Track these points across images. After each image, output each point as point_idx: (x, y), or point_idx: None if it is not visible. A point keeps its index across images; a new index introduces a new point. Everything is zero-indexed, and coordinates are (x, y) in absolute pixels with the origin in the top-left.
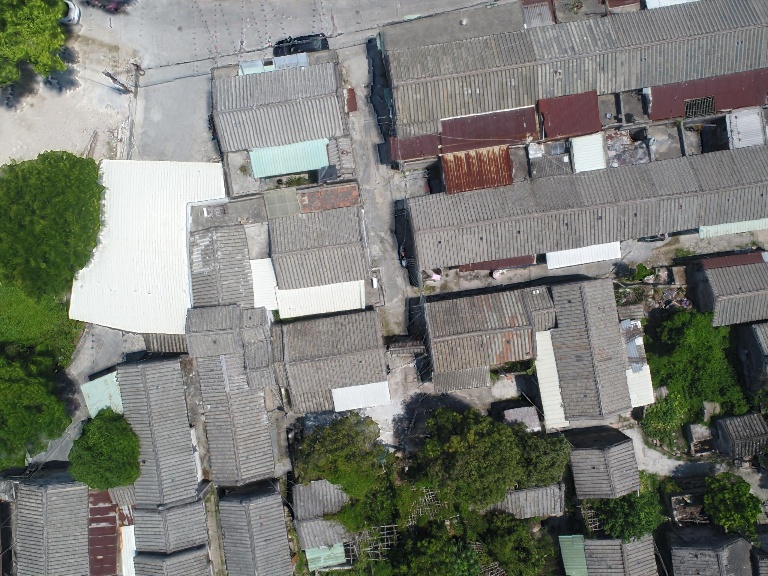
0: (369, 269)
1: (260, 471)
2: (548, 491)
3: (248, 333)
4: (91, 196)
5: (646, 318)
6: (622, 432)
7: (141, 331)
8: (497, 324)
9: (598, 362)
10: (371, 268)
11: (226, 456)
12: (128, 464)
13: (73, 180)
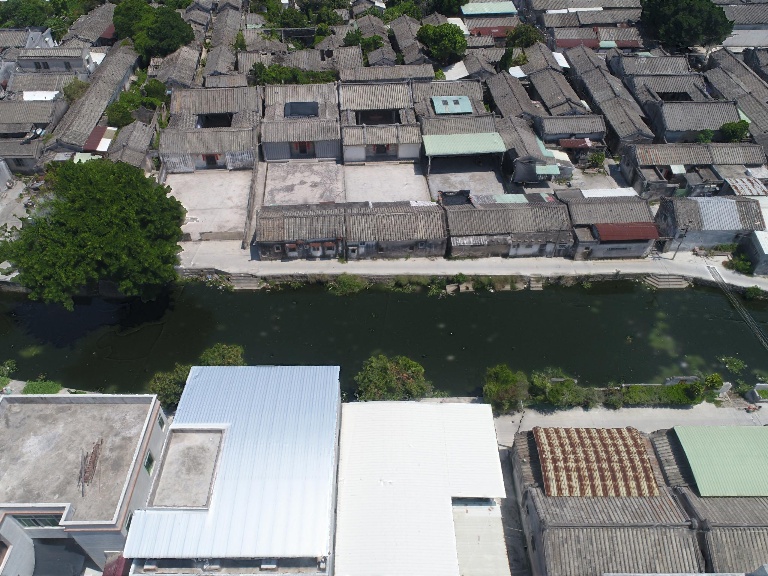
0: None
1: (236, 5)
2: (343, 11)
3: None
4: None
5: (385, 2)
6: None
7: None
8: None
9: None
10: None
11: (224, 2)
12: None
13: None
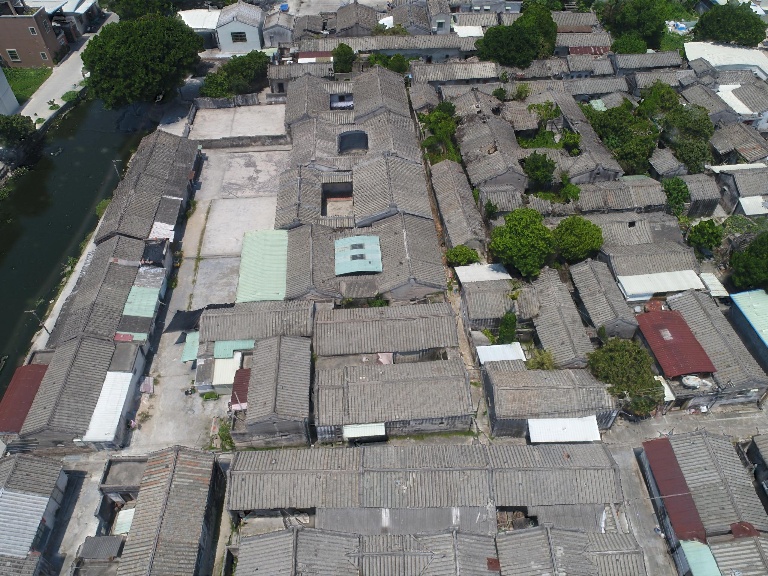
0: (762, 112)
1: (640, 81)
2: None
3: (707, 78)
4: (753, 32)
5: None
6: (711, 218)
7: (688, 58)
8: (763, 144)
9: (766, 174)
10: (762, 114)
11: None
12: (631, 48)
13: (758, 26)
